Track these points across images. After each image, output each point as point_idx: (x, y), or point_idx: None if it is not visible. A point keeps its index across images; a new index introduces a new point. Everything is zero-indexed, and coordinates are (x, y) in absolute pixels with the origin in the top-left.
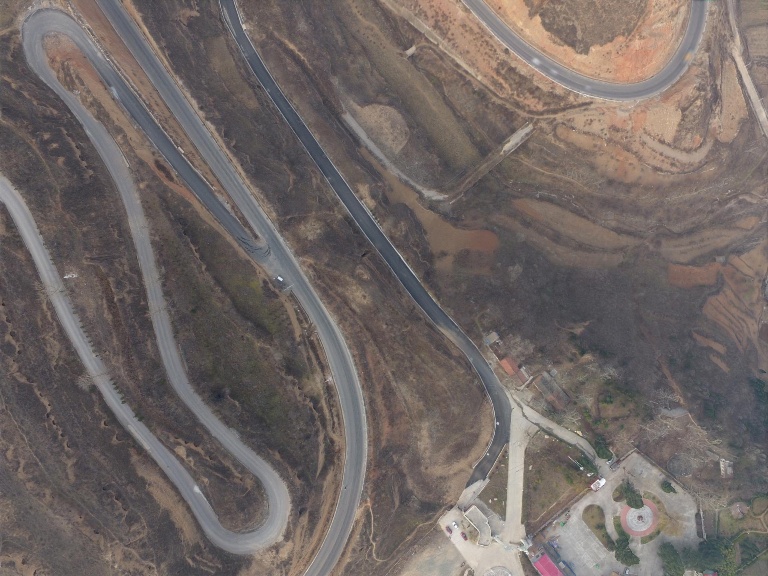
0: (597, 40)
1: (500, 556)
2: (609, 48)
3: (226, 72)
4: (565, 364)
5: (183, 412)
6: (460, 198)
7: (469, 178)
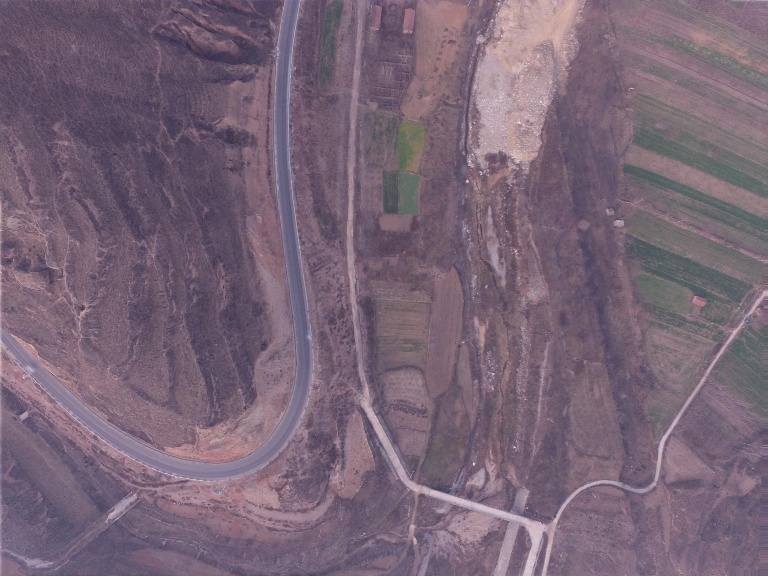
0: (166, 444)
1: None
2: (184, 447)
3: None
4: None
5: None
6: (68, 562)
7: (74, 546)
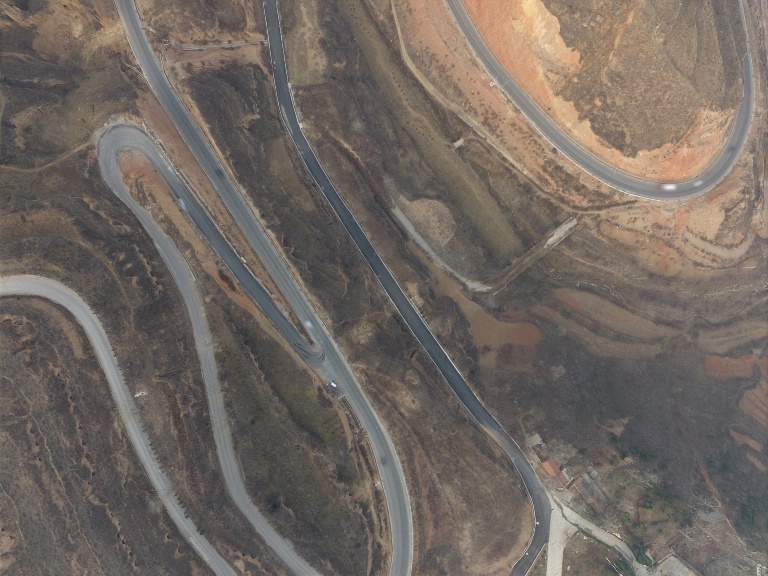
0: (645, 146)
1: None
2: (656, 153)
3: (284, 175)
4: (605, 466)
5: (240, 522)
6: (503, 289)
7: (512, 271)
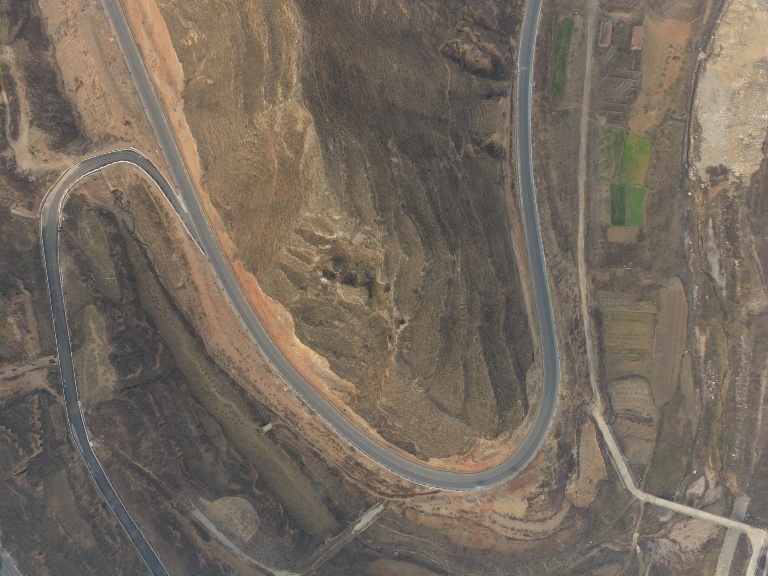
0: (434, 455)
1: None
2: (448, 458)
3: (64, 512)
4: None
5: None
6: (312, 574)
7: (320, 557)
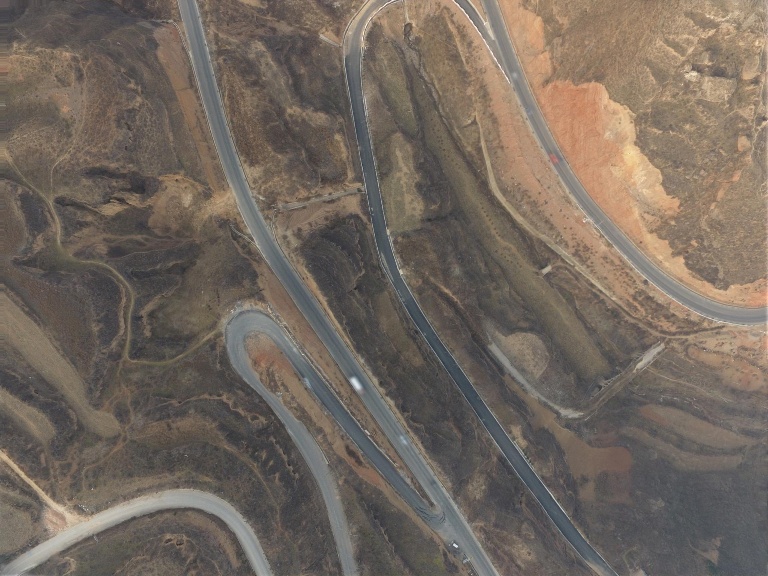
0: (738, 281)
1: None
2: (748, 285)
3: (393, 331)
4: None
5: None
6: (593, 414)
7: (603, 396)
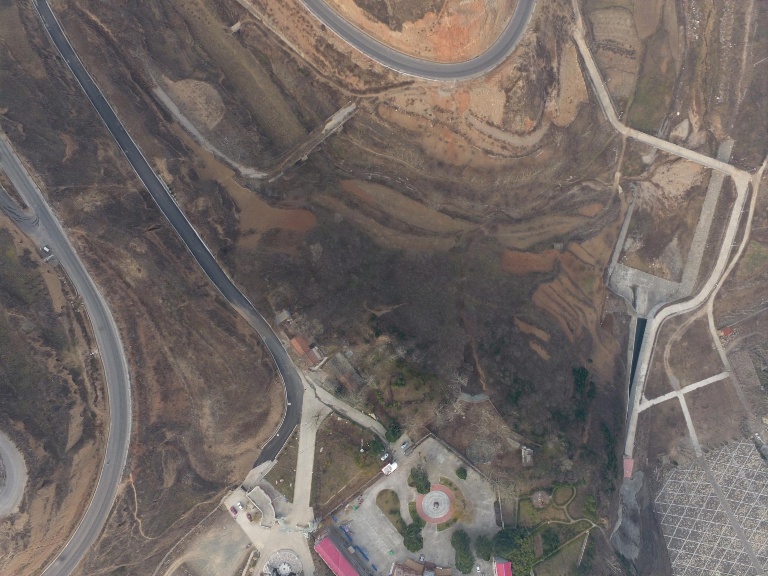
0: (408, 16)
1: (287, 539)
2: (422, 25)
3: (14, 41)
4: (361, 345)
5: None
6: (280, 177)
7: (289, 157)
